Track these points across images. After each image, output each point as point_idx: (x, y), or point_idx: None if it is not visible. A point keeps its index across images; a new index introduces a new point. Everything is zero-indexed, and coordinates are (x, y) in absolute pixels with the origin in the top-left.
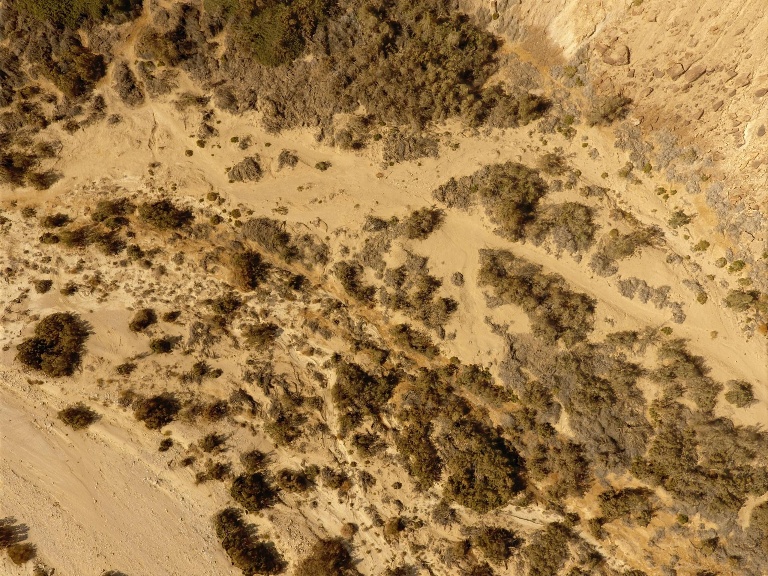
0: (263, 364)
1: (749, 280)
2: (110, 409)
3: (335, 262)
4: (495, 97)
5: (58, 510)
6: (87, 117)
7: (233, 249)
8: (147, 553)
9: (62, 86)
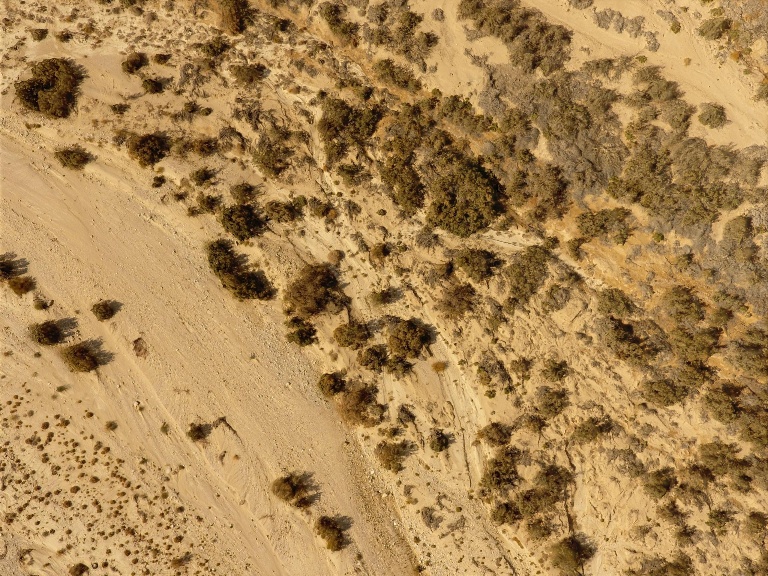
0: (251, 102)
1: (721, 9)
2: (105, 150)
3: (320, 3)
4: None
5: (56, 245)
6: None
7: None
8: (142, 284)
9: None
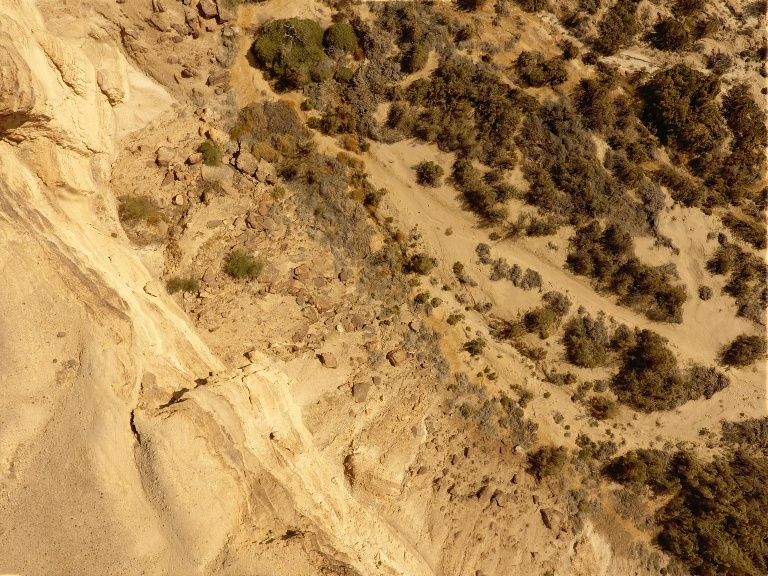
0: None
1: (412, 284)
2: None
3: None
4: (669, 483)
5: None
6: None
7: None
8: None
9: None
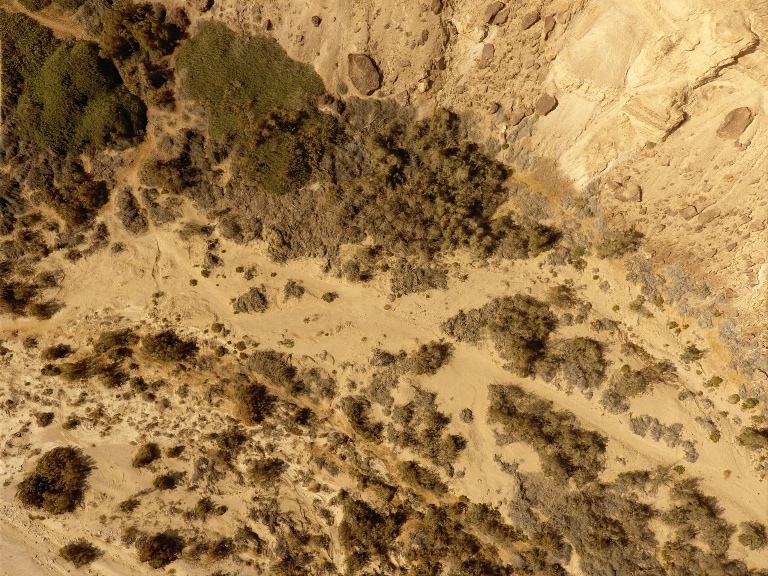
0: (269, 501)
1: (762, 418)
2: (113, 545)
3: (342, 397)
4: (505, 230)
5: None
6: (90, 246)
7: (238, 381)
8: None
9: (64, 215)
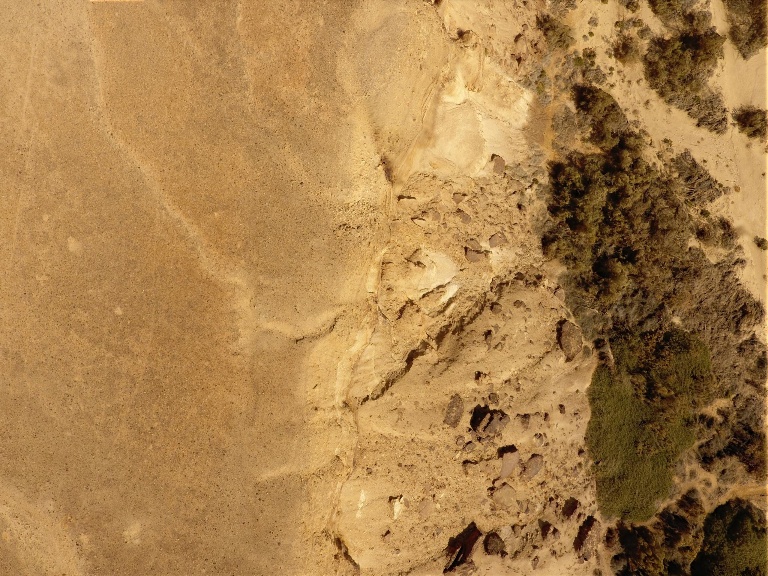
0: None
1: None
2: None
3: None
4: None
5: None
6: None
7: None
8: None
9: None
